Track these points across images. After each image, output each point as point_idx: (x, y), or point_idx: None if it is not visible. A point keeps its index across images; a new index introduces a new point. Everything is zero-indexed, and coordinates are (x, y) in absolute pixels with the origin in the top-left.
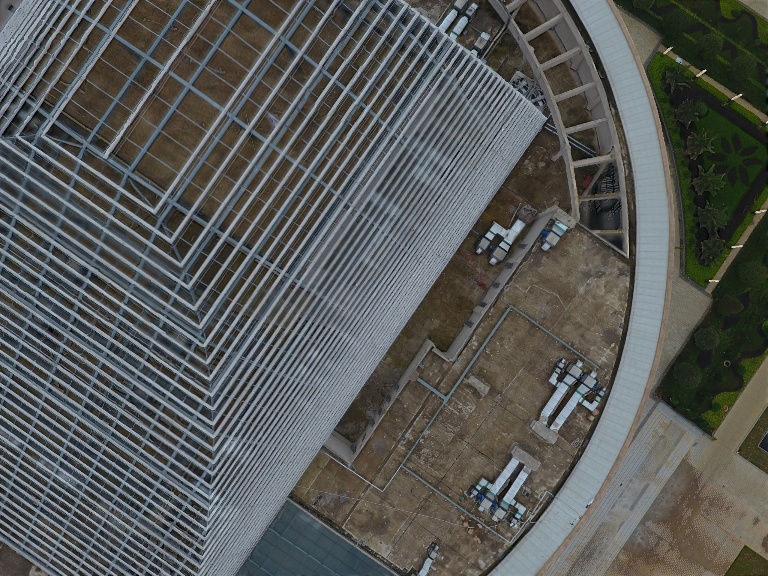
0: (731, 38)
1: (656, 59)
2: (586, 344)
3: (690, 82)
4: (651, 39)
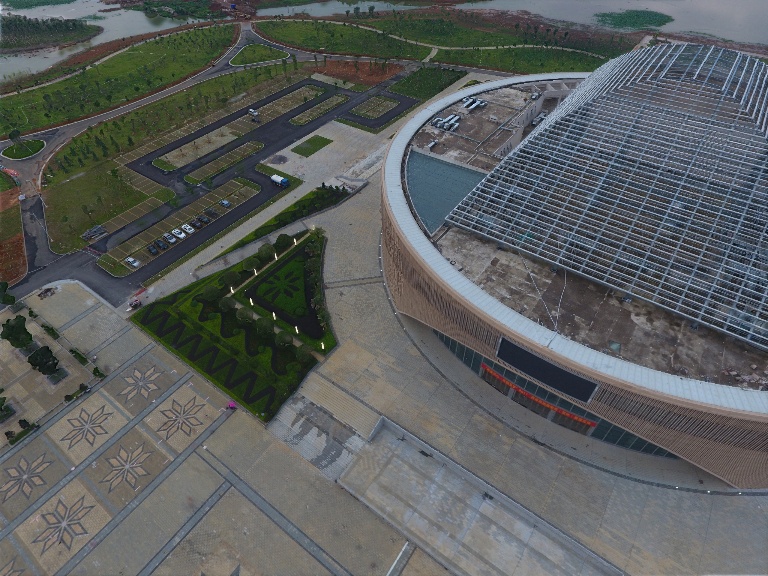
0: None
1: None
2: None
3: None
4: None
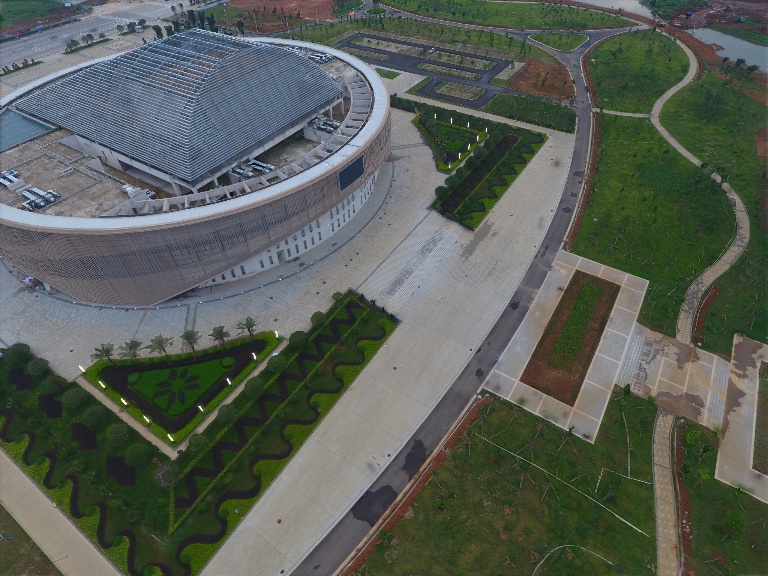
0: None
1: None
2: (62, 205)
3: None
4: None
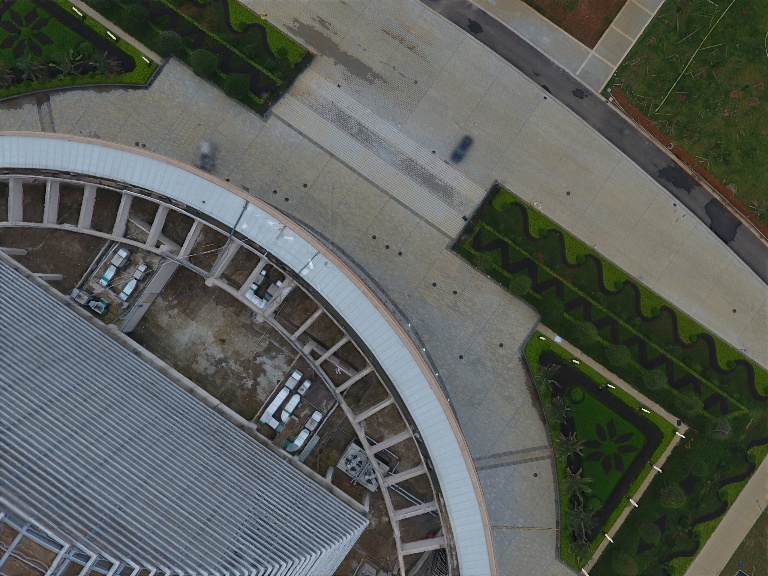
0: (612, 312)
1: (533, 341)
2: None
3: (568, 363)
4: (530, 317)
